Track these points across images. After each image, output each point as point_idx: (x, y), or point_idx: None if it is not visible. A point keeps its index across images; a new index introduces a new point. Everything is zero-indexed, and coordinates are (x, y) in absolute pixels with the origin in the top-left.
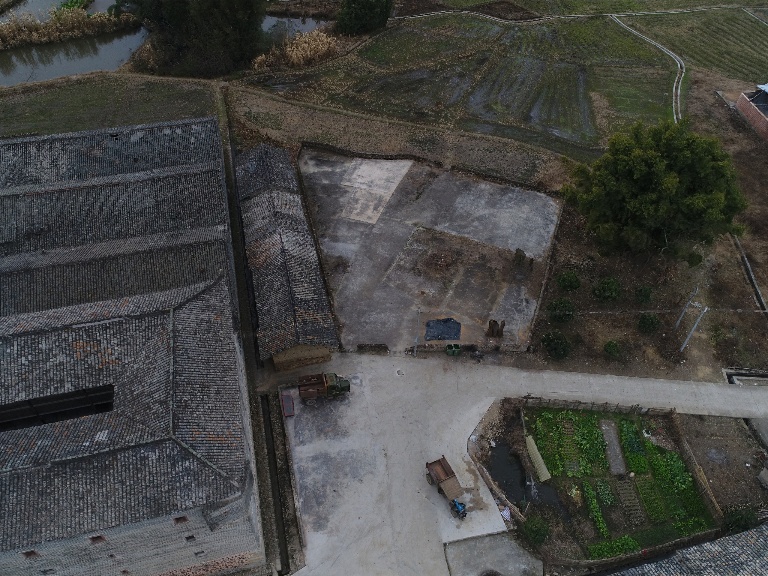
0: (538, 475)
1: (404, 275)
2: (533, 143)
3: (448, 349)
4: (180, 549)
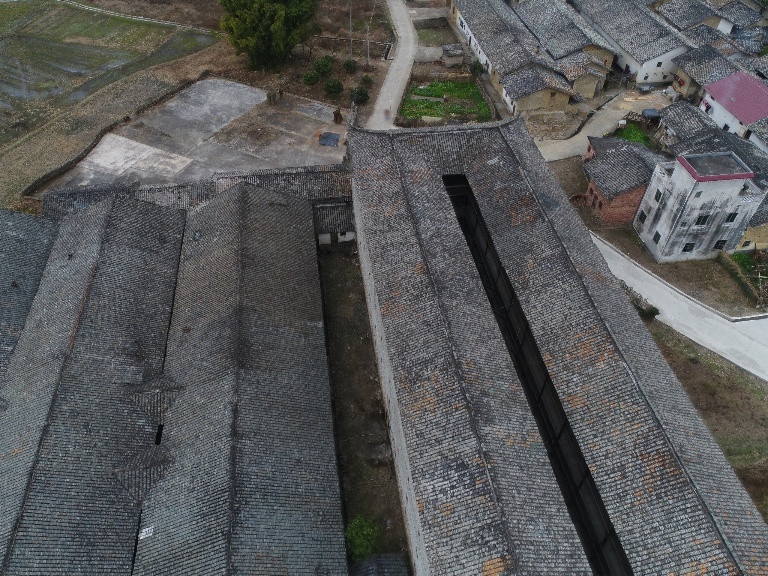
0: None
1: (267, 150)
2: (121, 77)
3: None
4: None
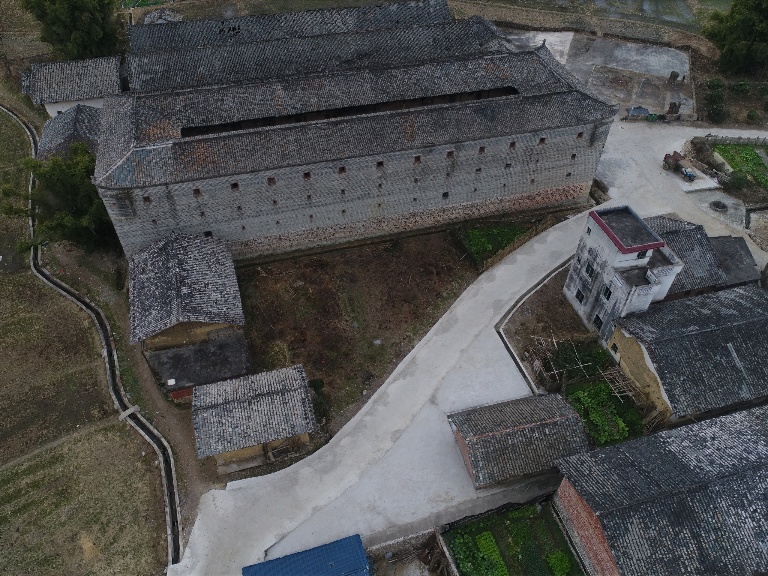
0: (725, 171)
1: (599, 88)
2: (653, 23)
3: (650, 115)
4: (564, 166)
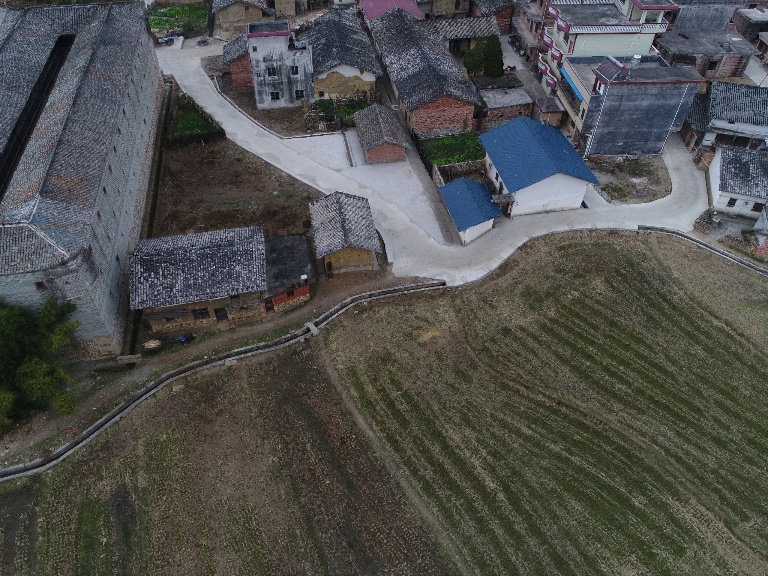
0: None
1: None
2: None
3: None
4: None
